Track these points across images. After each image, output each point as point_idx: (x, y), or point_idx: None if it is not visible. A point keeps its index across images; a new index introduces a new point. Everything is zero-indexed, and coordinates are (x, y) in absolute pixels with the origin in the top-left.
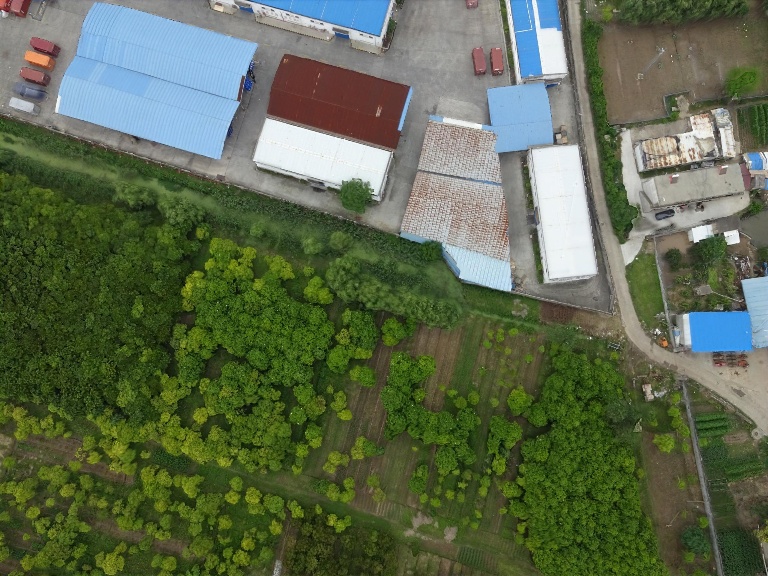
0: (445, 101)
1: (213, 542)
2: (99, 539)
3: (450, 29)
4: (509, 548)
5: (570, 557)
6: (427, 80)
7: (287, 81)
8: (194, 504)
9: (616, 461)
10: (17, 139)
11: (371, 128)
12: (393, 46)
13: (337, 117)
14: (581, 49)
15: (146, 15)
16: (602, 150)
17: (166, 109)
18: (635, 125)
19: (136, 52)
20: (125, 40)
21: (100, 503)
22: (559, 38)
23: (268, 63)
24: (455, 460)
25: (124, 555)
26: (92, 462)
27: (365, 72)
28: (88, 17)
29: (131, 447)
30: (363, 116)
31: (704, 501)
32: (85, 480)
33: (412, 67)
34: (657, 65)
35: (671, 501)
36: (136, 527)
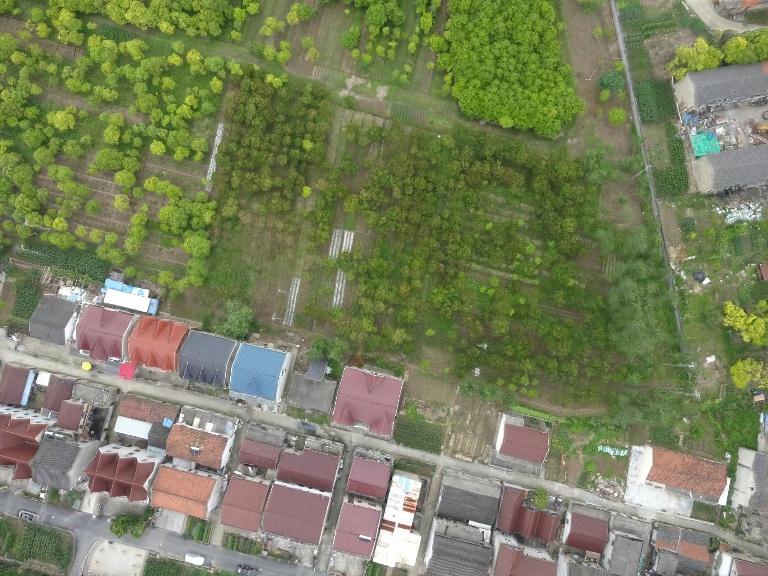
0: None
1: (158, 101)
2: (51, 108)
3: None
4: (438, 104)
5: (491, 88)
6: None
7: None
8: (139, 65)
9: (534, 3)
10: None
11: None
12: None
13: None
14: None
15: None
16: None
17: None
18: None
19: None
20: None
21: (50, 67)
22: None
23: None
24: (384, 14)
25: (74, 116)
26: (41, 33)
27: None
28: None
29: (78, 17)
30: None
31: (621, 57)
32: (35, 46)
33: None
34: None
35: (590, 58)
36: (84, 87)
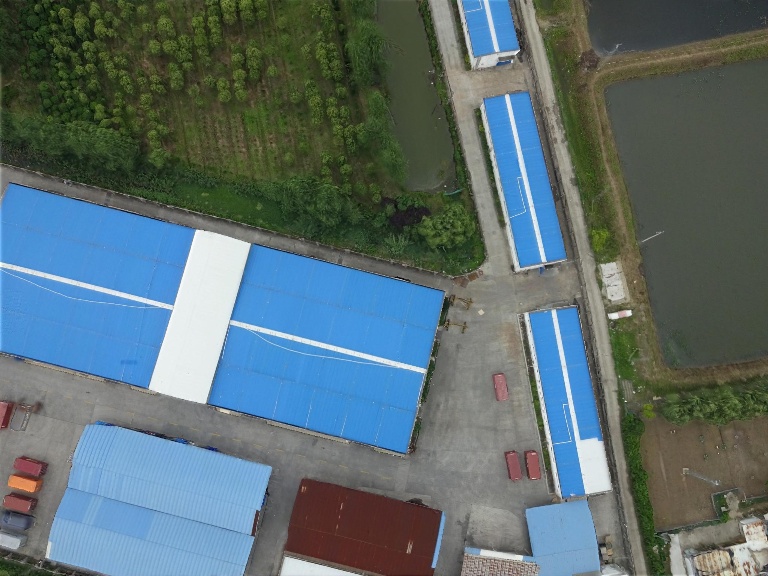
0: (478, 509)
1: None
2: None
3: (480, 424)
4: None
5: None
6: (457, 485)
7: (307, 516)
8: None
9: None
10: (2, 573)
11: (402, 565)
12: (419, 446)
13: (364, 554)
14: (622, 445)
15: (145, 437)
16: (651, 564)
17: (172, 554)
18: (683, 529)
19: (135, 485)
20: (123, 472)
21: None
22: (600, 449)
23: (282, 472)
24: None
25: None
26: None
27: (389, 478)
28: (80, 445)
29: None
30: (392, 553)
31: None
32: None
33: (440, 470)
34: (703, 457)
35: None
36: None
